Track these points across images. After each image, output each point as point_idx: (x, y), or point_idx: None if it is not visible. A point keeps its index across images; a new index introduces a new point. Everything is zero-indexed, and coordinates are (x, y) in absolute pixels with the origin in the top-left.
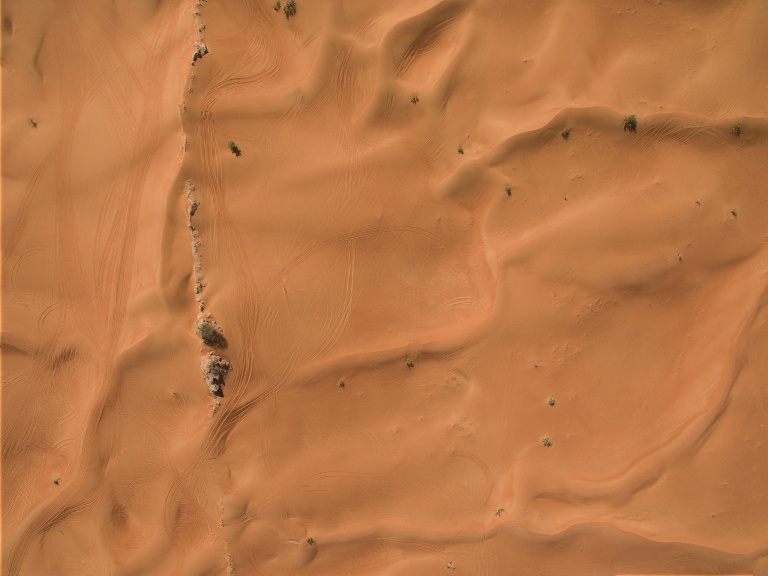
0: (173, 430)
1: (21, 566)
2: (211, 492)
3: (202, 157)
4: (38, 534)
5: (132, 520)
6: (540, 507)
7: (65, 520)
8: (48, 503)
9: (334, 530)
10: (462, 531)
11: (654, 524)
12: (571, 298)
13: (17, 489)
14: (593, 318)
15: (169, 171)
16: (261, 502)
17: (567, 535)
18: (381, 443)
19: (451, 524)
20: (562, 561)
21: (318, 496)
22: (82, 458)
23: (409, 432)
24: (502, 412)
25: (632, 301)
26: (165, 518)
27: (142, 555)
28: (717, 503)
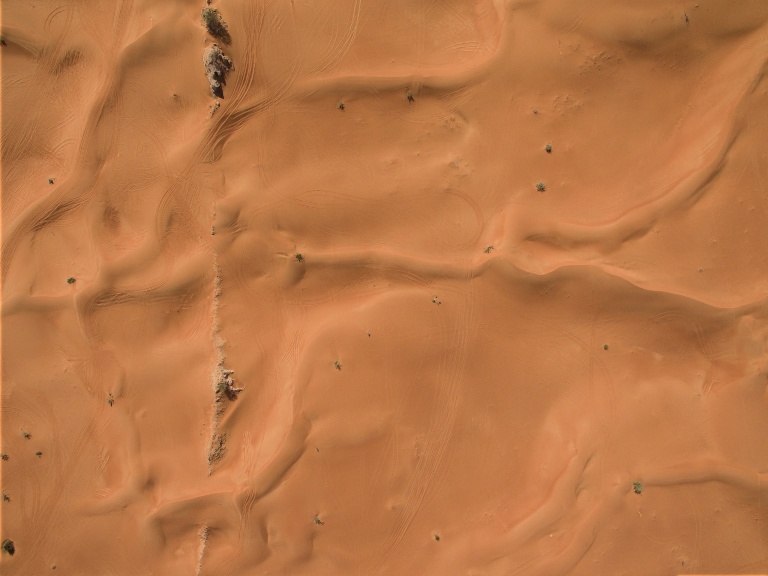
0: (171, 136)
1: (10, 264)
2: (204, 198)
3: None
4: (30, 232)
5: (124, 226)
6: (529, 248)
7: (57, 221)
8: (42, 201)
9: (323, 251)
10: (450, 265)
11: (641, 273)
12: (575, 47)
13: (12, 192)
14: (596, 72)
15: None
16: (253, 210)
17: (554, 277)
18: (376, 171)
19: (440, 257)
20: (547, 308)
21: (310, 213)
22: (79, 155)
23: (405, 165)
24: (498, 155)
25: (636, 61)
26: (157, 224)
27: (131, 255)
28: (705, 259)
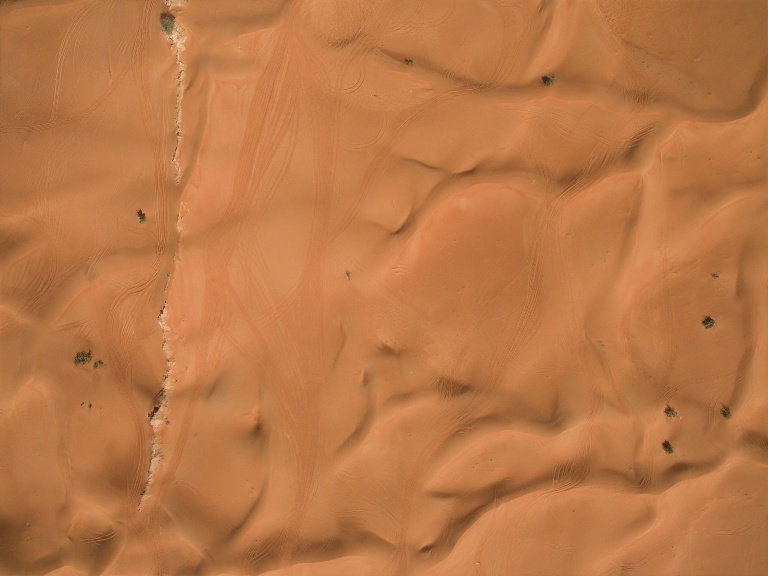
0: None
1: None
2: None
3: (169, 209)
4: None
5: None
6: None
7: None
8: None
9: None
10: None
11: None
12: None
13: None
14: None
15: (199, 197)
16: None
17: None
18: None
19: None
20: None
21: None
22: None
23: None
24: None
25: None
26: None
27: None
28: None
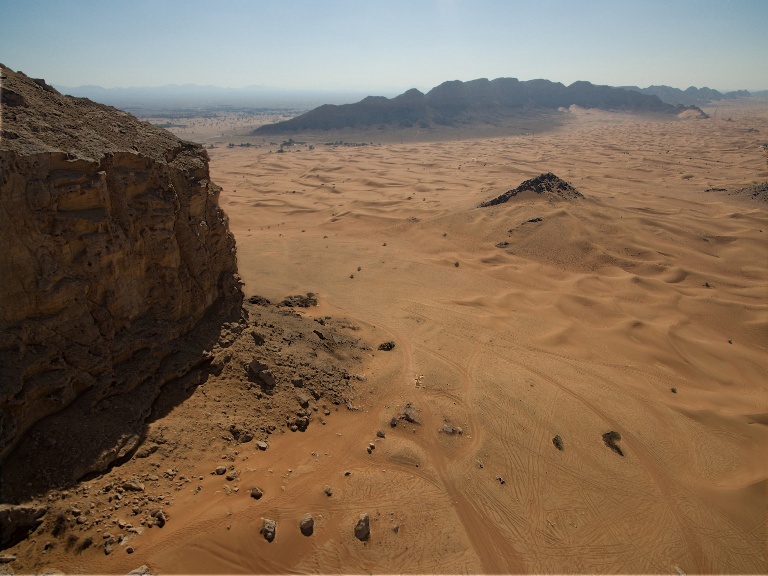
0: None
1: None
2: None
3: None
4: None
5: None
6: None
7: None
8: None
9: None
10: None
11: None
12: None
13: None
14: None
15: None
16: None
17: None
18: None
19: None
20: None
21: None
22: None
23: None
24: None
25: None
26: None
27: None
28: None
